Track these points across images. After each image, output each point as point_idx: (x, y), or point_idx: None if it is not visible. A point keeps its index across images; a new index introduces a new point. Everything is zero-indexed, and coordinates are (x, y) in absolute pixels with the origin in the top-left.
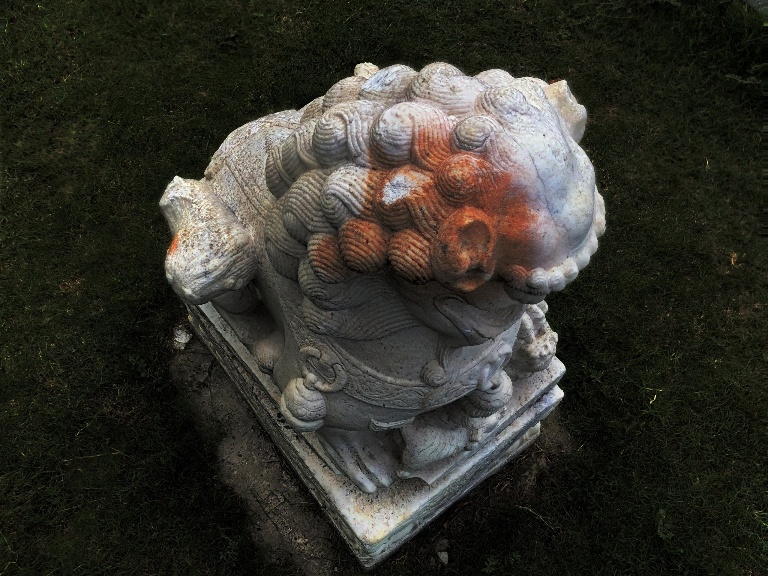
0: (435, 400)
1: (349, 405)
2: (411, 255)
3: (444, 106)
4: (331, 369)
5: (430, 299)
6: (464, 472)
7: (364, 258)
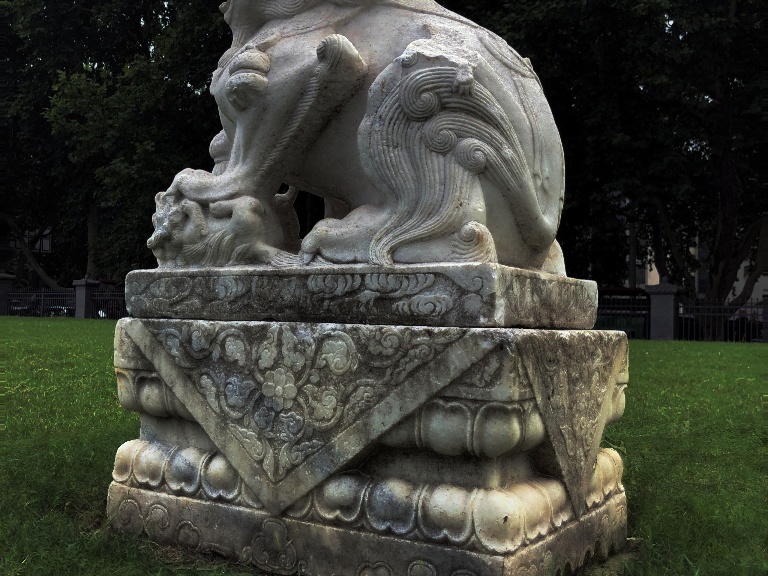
0: None
1: None
2: None
3: None
4: None
5: None
6: None
7: None
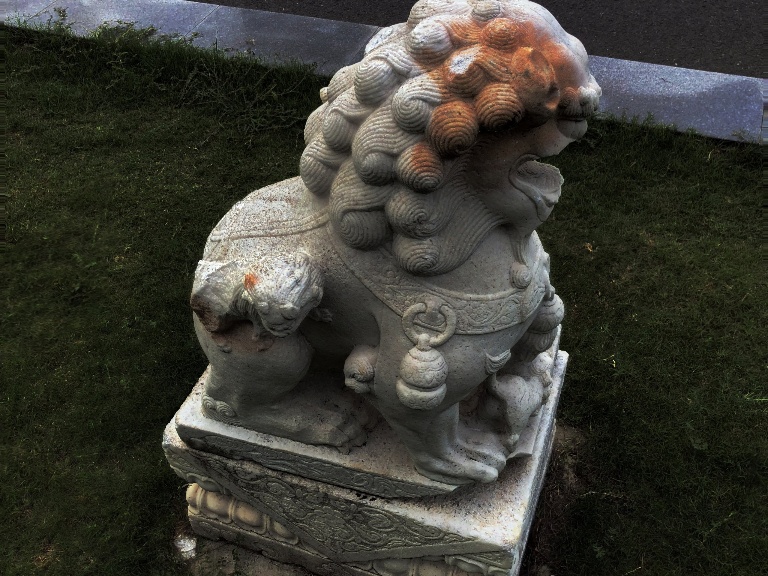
0: (529, 303)
1: (465, 347)
2: (502, 98)
3: (450, 12)
4: (439, 315)
5: (507, 173)
6: (542, 447)
7: (464, 127)
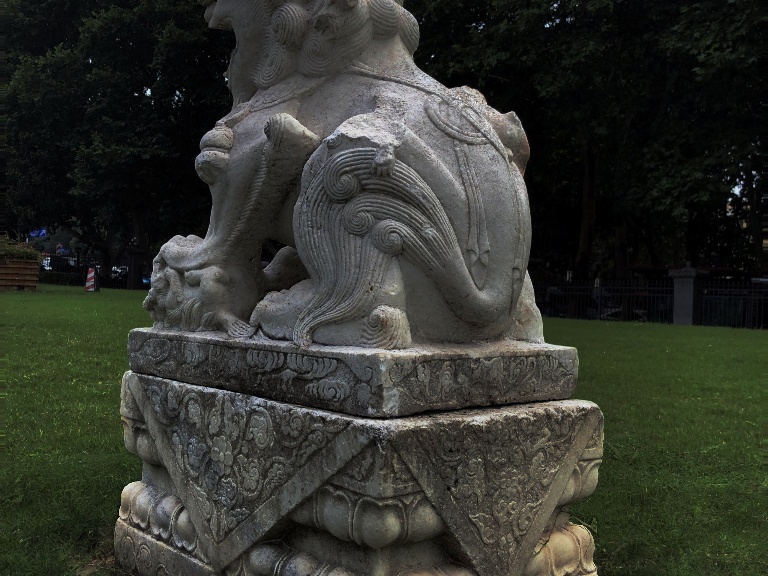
0: None
1: None
2: None
3: None
4: None
5: None
6: None
7: None
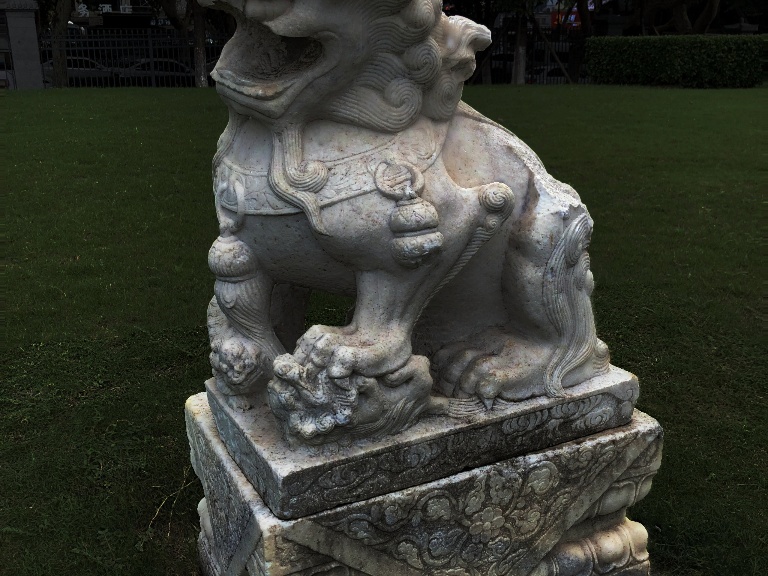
0: None
1: None
2: None
3: None
4: None
5: None
6: None
7: None
